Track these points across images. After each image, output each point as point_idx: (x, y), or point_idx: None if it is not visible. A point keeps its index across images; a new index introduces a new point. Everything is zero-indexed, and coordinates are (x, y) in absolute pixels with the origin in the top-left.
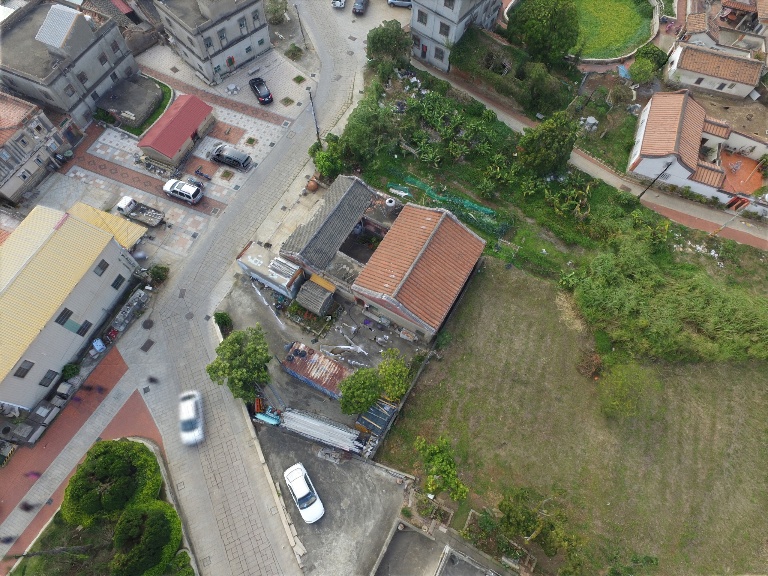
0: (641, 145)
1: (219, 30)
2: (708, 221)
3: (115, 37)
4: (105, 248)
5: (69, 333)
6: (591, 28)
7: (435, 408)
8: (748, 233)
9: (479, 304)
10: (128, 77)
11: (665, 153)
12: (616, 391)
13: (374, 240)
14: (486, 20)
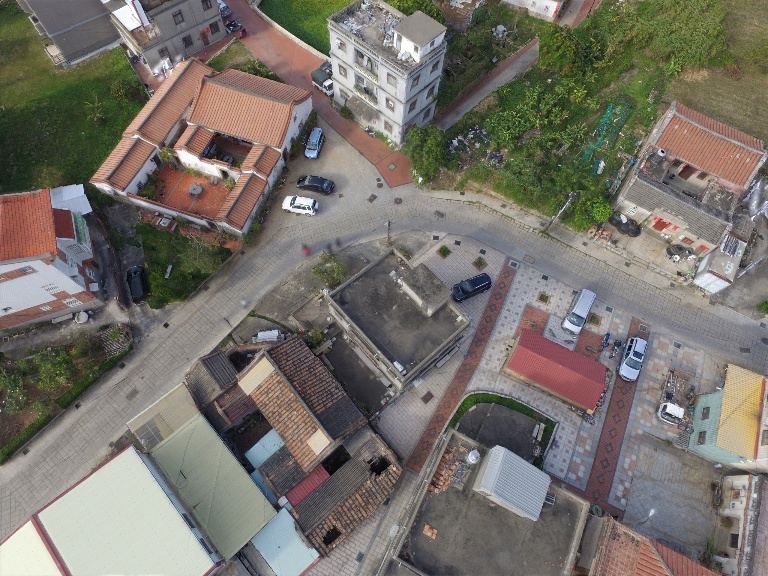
0: None
1: None
2: None
3: None
4: None
5: None
6: None
7: None
8: None
9: None
10: None
11: None
12: None
13: None
14: None
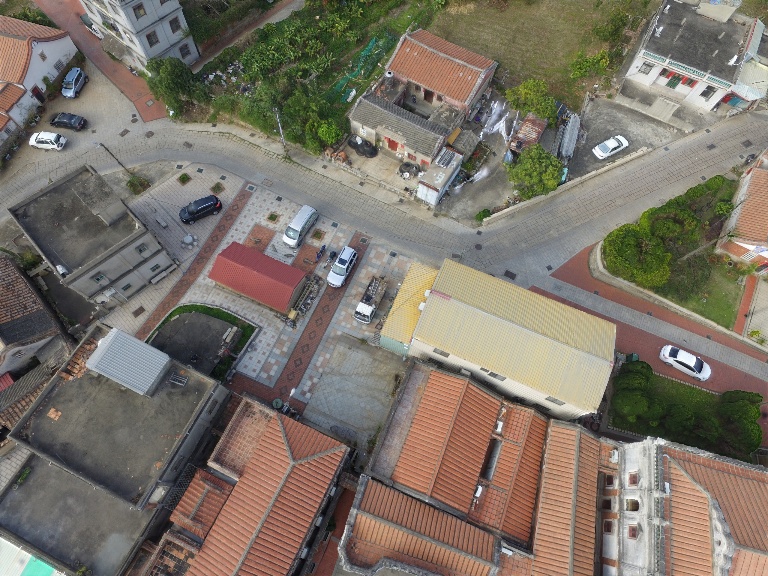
0: None
1: None
2: None
3: None
4: None
5: None
6: None
7: None
8: None
9: None
10: None
11: None
12: None
13: None
14: None
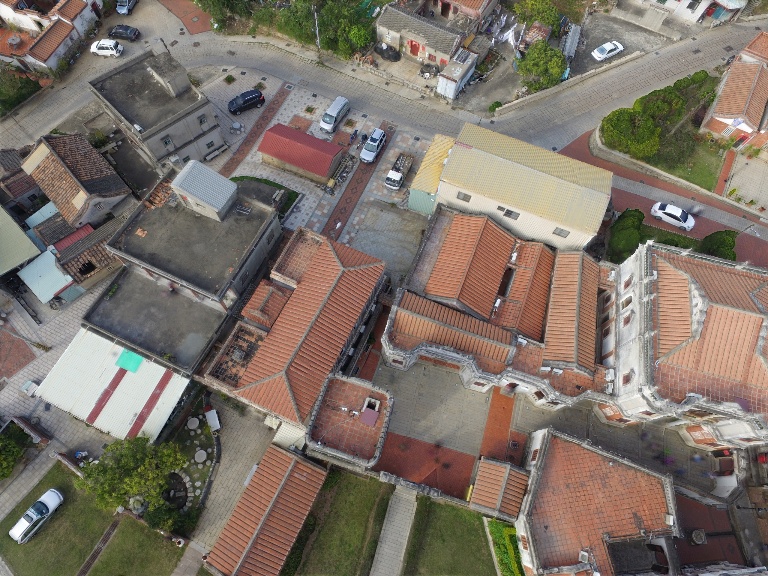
0: None
1: None
2: None
3: None
4: None
5: None
6: None
7: None
8: None
9: None
10: None
11: None
12: None
13: None
14: None
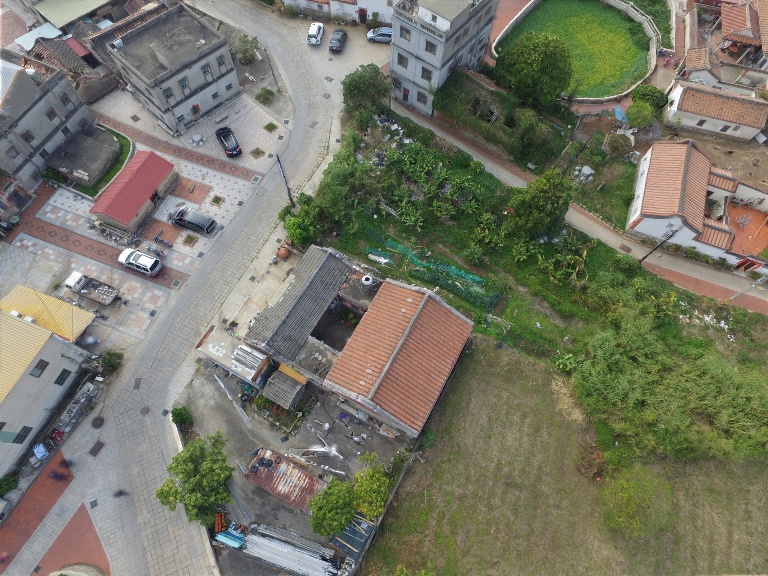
0: (642, 202)
1: (180, 79)
2: (715, 284)
3: (65, 89)
4: (42, 348)
5: (3, 445)
6: (584, 62)
7: (419, 520)
8: (759, 298)
9: (467, 391)
10: (83, 129)
11: (668, 214)
12: (621, 505)
13: (351, 316)
14: (472, 60)
